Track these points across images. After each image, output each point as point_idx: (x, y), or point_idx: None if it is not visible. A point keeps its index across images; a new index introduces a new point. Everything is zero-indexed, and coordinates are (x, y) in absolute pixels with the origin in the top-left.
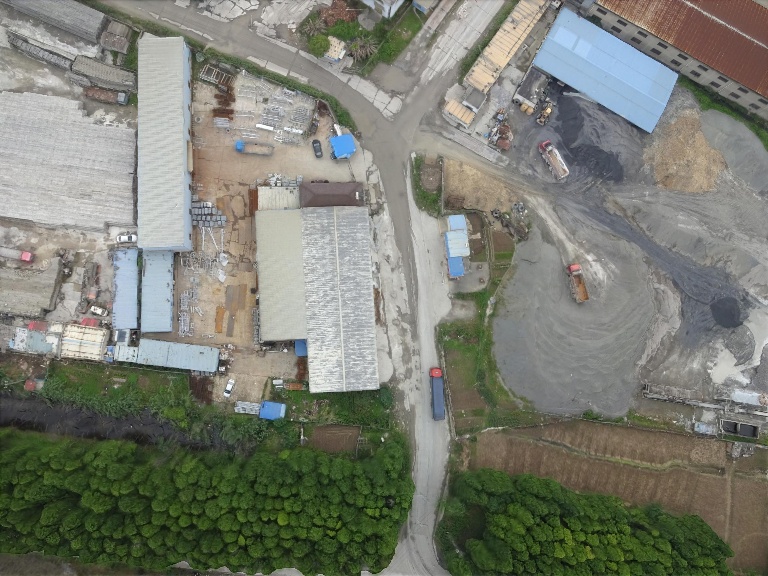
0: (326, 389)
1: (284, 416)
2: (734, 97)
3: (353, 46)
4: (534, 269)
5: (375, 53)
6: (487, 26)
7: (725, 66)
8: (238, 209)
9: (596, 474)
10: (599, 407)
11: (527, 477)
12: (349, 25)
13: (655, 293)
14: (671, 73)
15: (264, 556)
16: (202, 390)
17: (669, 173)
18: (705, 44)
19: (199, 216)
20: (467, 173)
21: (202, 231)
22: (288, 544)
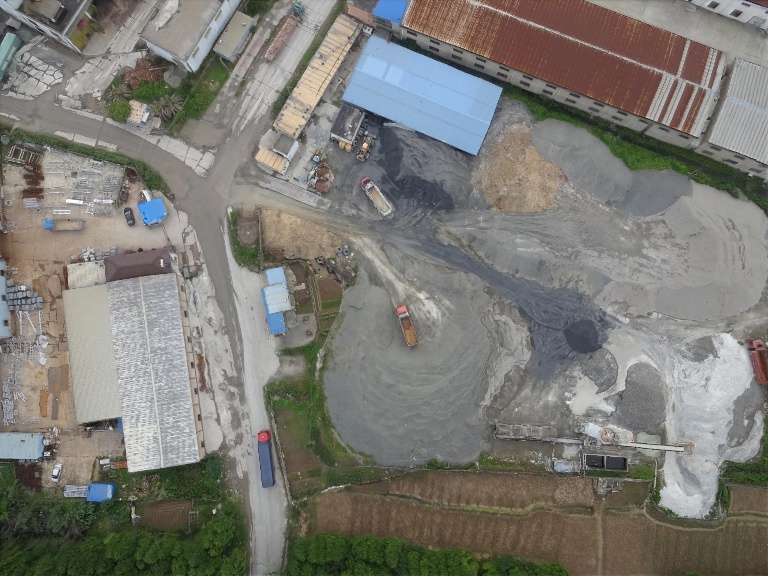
0: (144, 467)
1: (111, 497)
2: (571, 102)
3: (155, 107)
4: (359, 316)
5: (180, 111)
6: (298, 65)
7: (549, 73)
8: (55, 288)
9: (451, 526)
10: (443, 455)
11: (362, 540)
12: (153, 85)
13: (496, 326)
14: (494, 88)
15: None
16: (29, 477)
17: (500, 195)
18: (525, 52)
19: (15, 301)
20: (284, 223)
21: (19, 315)
22: None
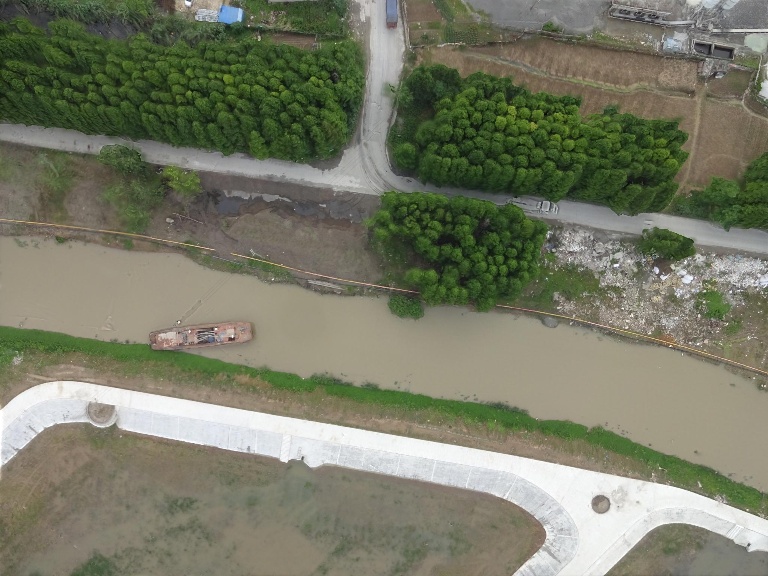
0: None
1: (241, 21)
2: None
3: None
4: None
5: None
6: None
7: None
8: None
9: (556, 93)
10: (559, 19)
11: None
12: None
13: None
14: None
15: (212, 117)
16: None
17: None
18: None
19: None
20: None
21: None
22: (232, 96)
